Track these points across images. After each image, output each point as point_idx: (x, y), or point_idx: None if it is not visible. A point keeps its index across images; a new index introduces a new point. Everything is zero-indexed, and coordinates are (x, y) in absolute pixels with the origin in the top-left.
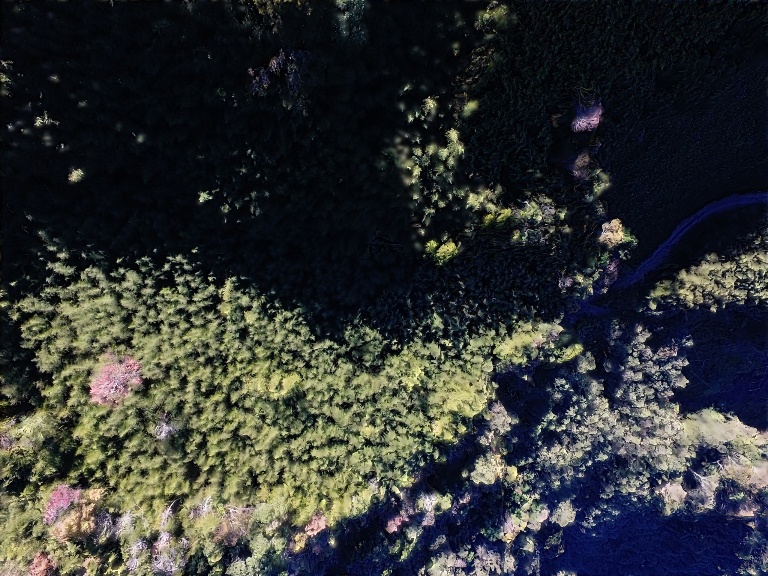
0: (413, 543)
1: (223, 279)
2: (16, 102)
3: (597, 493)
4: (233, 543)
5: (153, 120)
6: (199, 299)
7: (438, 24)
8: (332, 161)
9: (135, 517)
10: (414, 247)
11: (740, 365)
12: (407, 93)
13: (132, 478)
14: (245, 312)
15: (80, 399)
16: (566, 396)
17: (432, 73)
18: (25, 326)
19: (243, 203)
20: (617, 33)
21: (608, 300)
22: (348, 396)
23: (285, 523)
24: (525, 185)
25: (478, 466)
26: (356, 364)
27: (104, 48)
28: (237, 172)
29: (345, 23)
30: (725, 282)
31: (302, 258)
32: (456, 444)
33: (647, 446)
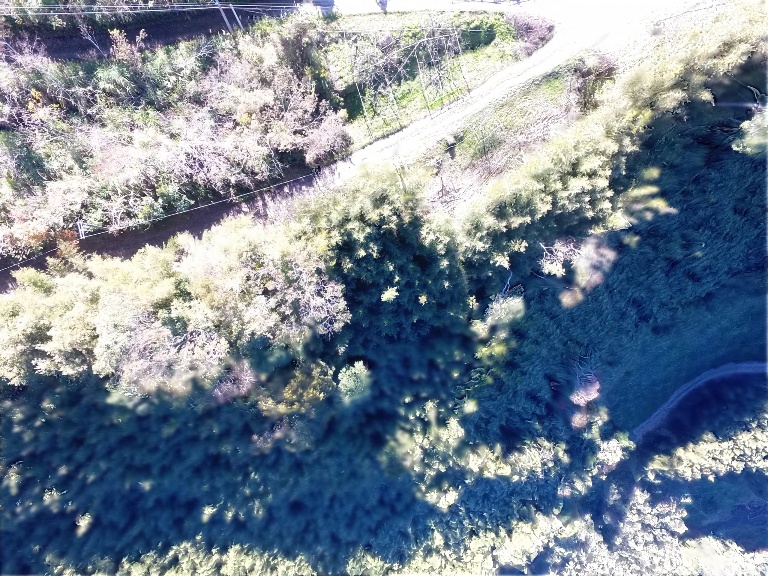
0: None
1: (226, 546)
2: (25, 484)
3: None
4: None
5: (159, 470)
6: (203, 570)
7: (438, 359)
8: (334, 462)
9: None
10: (415, 498)
11: (738, 498)
12: (408, 404)
13: None
14: (248, 573)
15: None
16: None
17: (432, 385)
18: None
19: (247, 508)
20: (614, 311)
21: None
22: None
23: None
24: (524, 433)
25: None
26: None
27: (112, 441)
28: (241, 490)
29: (347, 398)
30: (722, 459)
31: (304, 508)
32: None
33: None
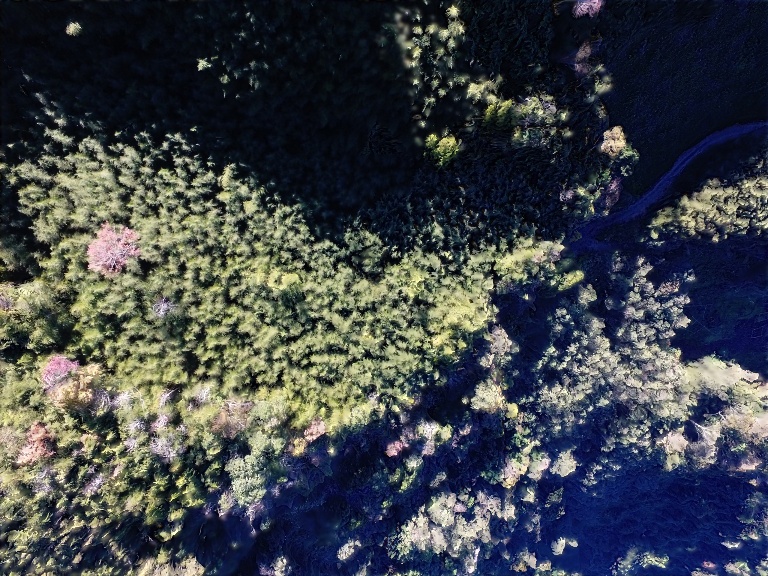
0: (413, 475)
1: (222, 166)
2: None
3: (598, 447)
4: (232, 436)
5: None
6: (198, 185)
7: None
8: (332, 33)
9: (133, 398)
10: (414, 141)
11: (742, 310)
12: None
13: (130, 362)
14: (244, 202)
15: (78, 274)
16: (567, 331)
17: None
18: (23, 191)
19: (242, 74)
20: None
21: (609, 234)
22: (348, 301)
23: (284, 423)
24: (526, 81)
25: (478, 391)
26: (356, 271)
27: None
28: (236, 37)
29: None
30: (727, 208)
31: (302, 153)
32: (456, 364)
33: (648, 391)
